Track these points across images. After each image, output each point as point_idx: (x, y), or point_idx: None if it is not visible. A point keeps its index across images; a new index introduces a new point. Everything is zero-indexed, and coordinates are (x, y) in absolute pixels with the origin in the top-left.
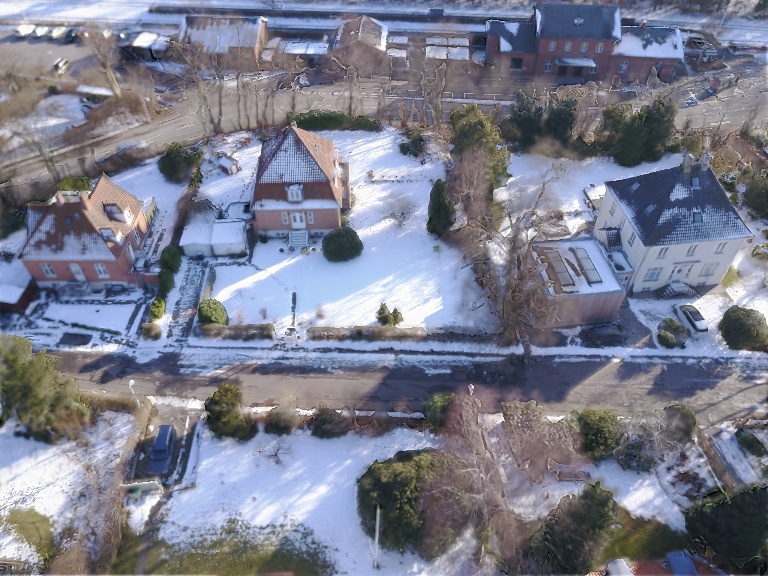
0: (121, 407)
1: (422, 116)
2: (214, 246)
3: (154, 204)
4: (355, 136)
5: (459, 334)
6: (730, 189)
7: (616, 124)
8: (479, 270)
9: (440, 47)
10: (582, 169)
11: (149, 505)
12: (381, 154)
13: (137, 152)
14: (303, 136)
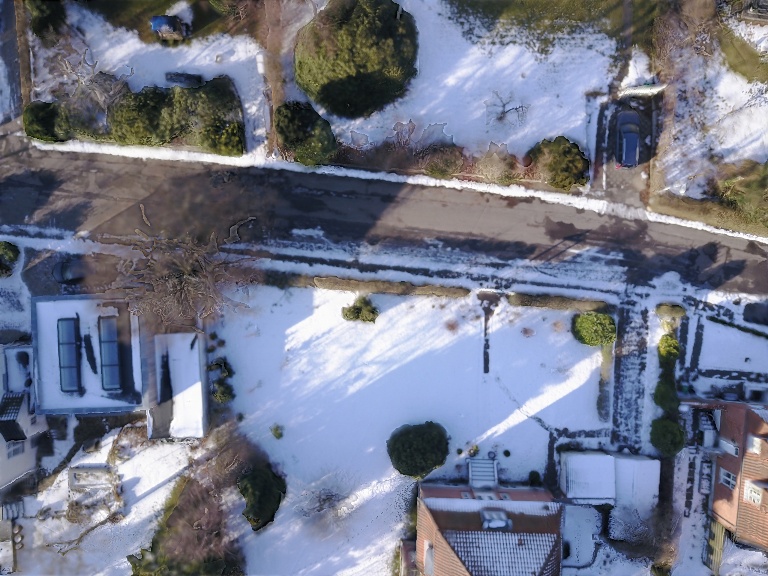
0: (685, 202)
1: None
2: None
3: (714, 568)
4: None
5: None
6: None
7: None
8: (224, 386)
9: None
10: None
11: (631, 78)
12: None
13: None
14: None
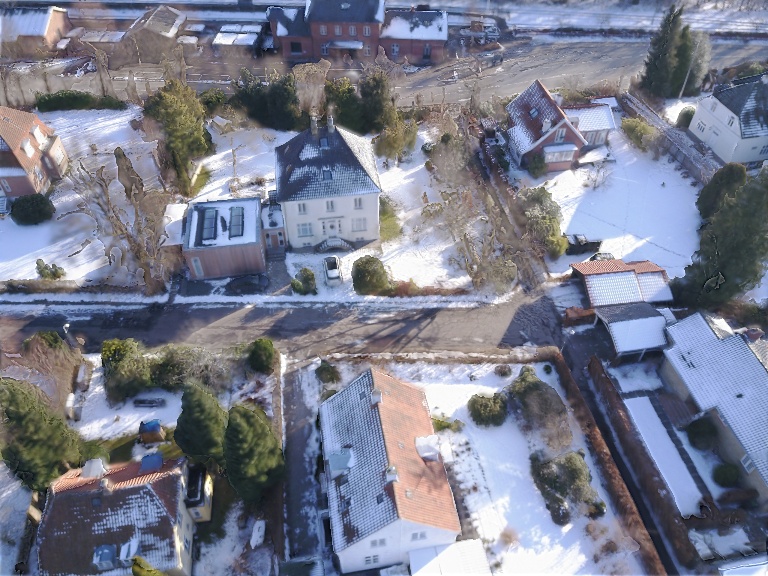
0: None
1: None
2: None
3: None
4: (99, 114)
5: (112, 286)
6: (431, 156)
7: (336, 98)
8: None
9: (230, 34)
10: None
11: None
12: (114, 130)
13: None
14: None
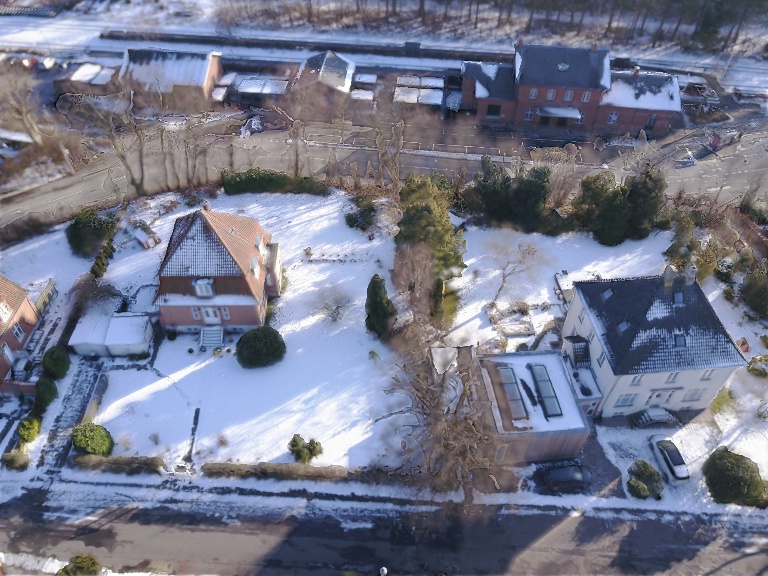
0: None
1: (378, 176)
2: (109, 346)
3: (51, 286)
4: (298, 201)
5: (387, 473)
6: (725, 279)
7: (596, 197)
8: None
9: (411, 88)
10: (556, 247)
11: None
12: (324, 225)
13: (45, 217)
14: (215, 221)
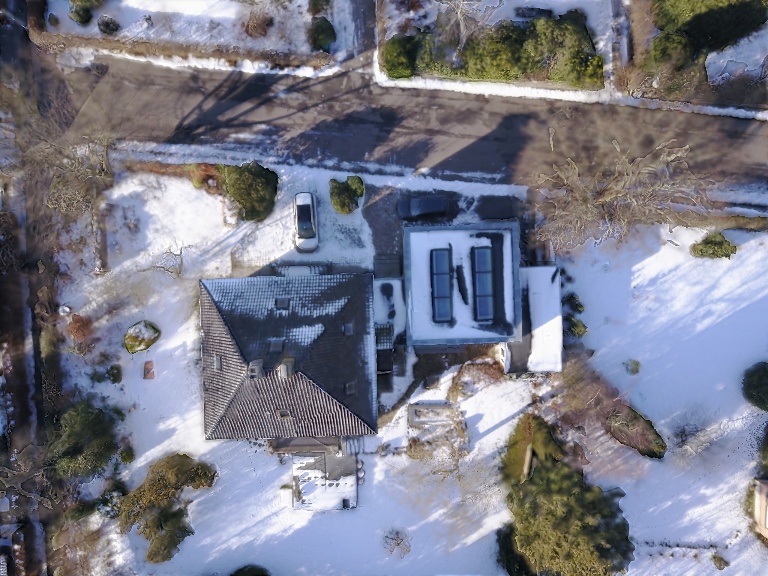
0: None
1: None
2: None
3: None
4: None
5: None
6: (118, 484)
7: None
8: None
9: None
10: (337, 568)
11: None
12: None
13: None
14: None
